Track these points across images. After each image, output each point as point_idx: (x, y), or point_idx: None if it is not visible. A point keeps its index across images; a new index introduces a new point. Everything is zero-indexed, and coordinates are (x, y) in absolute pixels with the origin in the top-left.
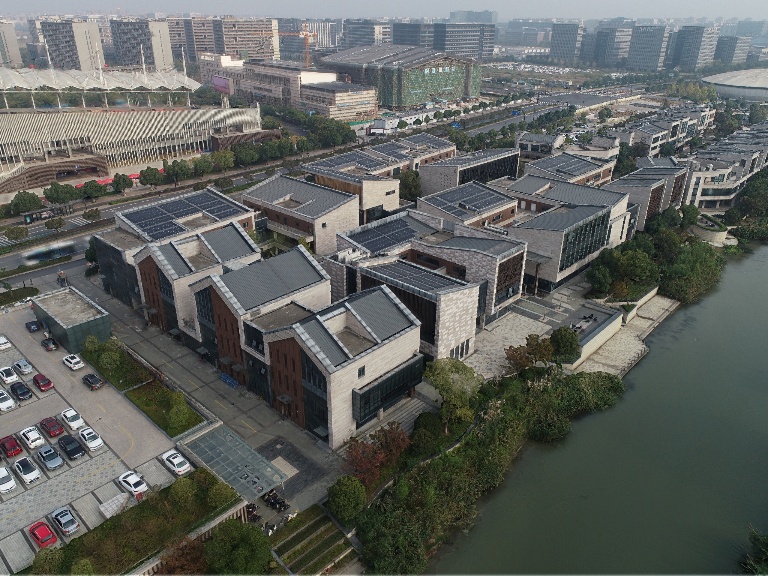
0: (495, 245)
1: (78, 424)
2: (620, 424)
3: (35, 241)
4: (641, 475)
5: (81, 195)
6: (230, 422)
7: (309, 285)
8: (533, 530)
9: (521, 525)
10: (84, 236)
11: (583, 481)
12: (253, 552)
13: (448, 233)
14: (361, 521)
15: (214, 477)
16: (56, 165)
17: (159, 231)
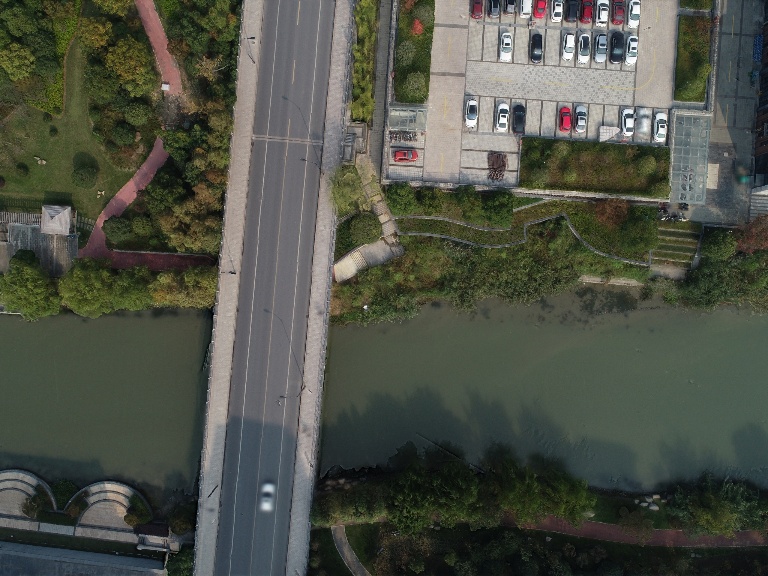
0: None
1: (634, 25)
2: None
3: None
4: None
5: None
6: (720, 98)
7: None
8: None
9: None
10: None
11: None
12: (645, 246)
13: None
14: (711, 260)
15: (669, 165)
16: None
17: None
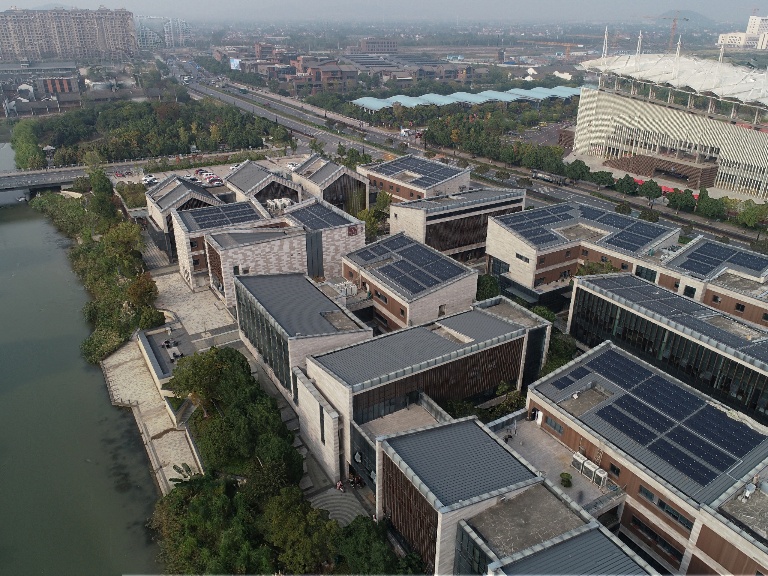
0: (237, 241)
1: None
2: (63, 343)
3: (487, 180)
4: (23, 335)
5: (586, 178)
6: None
7: (241, 190)
8: (49, 289)
9: (57, 289)
10: None
11: (52, 317)
12: None
13: None
14: None
15: None
16: (658, 161)
17: (387, 169)
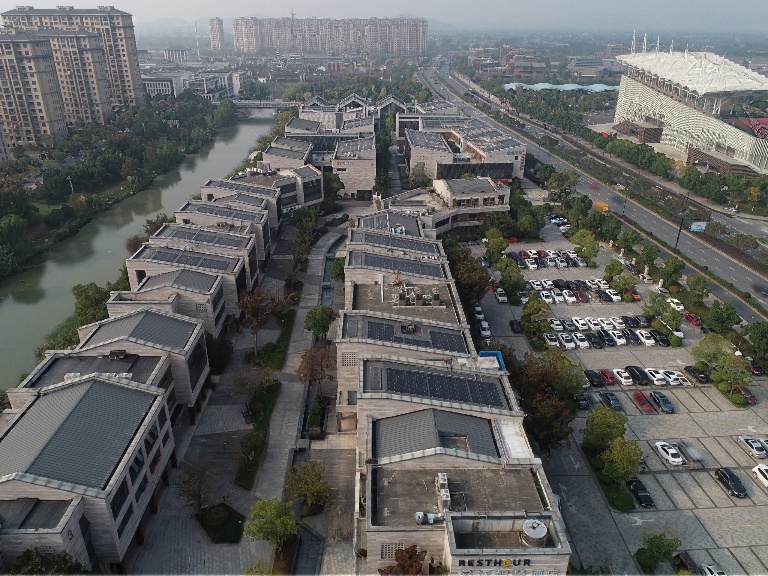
0: None
1: None
2: None
3: None
4: None
5: None
6: None
7: None
8: None
9: None
10: (510, 131)
11: None
12: None
13: (339, 119)
14: None
15: None
16: None
17: None
